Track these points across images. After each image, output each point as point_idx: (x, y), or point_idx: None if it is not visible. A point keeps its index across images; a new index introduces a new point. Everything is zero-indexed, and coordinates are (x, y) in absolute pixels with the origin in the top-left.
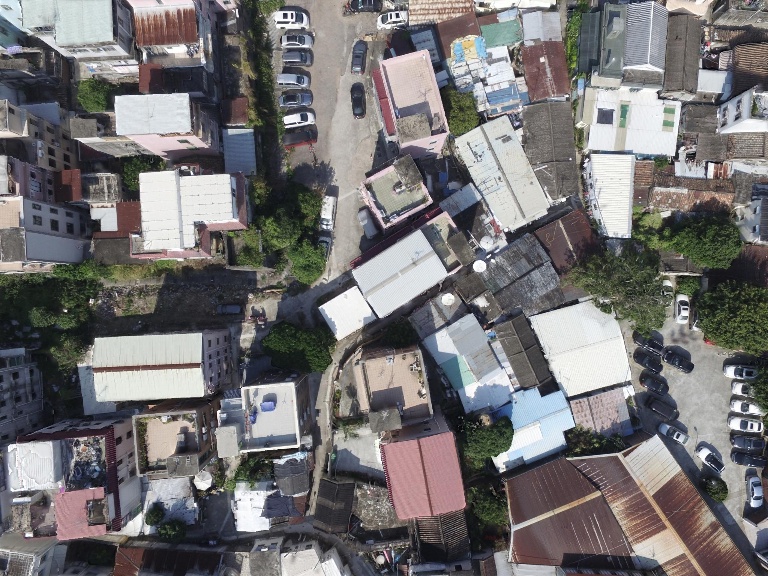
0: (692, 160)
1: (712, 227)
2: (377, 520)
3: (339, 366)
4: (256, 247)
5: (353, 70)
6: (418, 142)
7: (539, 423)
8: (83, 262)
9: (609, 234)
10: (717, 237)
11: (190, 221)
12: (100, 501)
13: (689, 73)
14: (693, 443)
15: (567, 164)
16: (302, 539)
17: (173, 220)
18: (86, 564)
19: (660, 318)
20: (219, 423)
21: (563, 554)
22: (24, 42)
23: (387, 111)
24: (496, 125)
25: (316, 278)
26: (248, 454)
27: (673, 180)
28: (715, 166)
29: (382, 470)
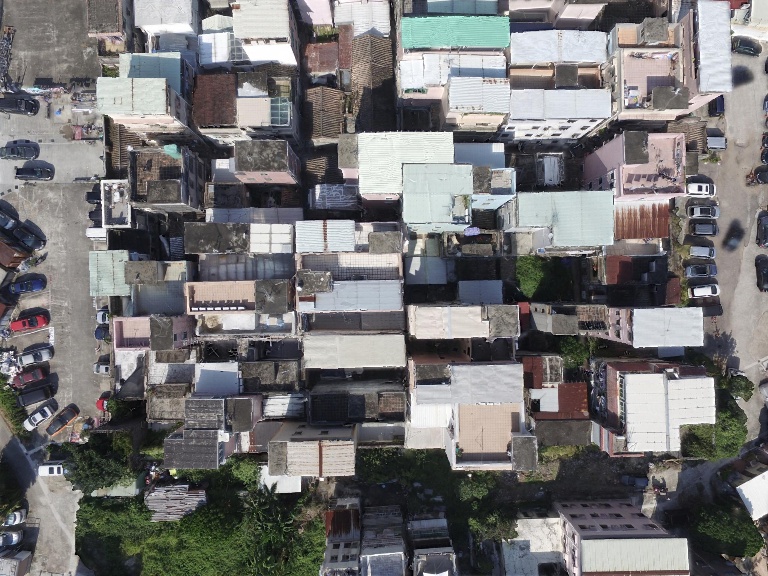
0: None
1: None
2: None
3: None
4: (708, 439)
5: (765, 245)
6: None
7: None
8: None
9: None
10: None
11: (676, 425)
12: None
13: None
14: None
15: None
16: None
17: (660, 423)
18: None
19: None
20: None
21: None
22: None
23: None
24: None
25: None
26: None
27: None
28: None
29: None
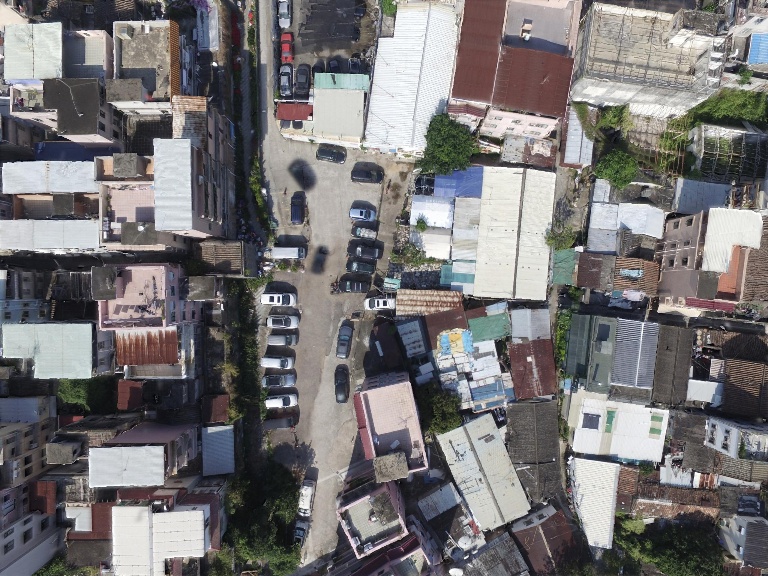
0: (678, 465)
1: (694, 558)
2: None
3: None
4: (229, 564)
5: (338, 356)
6: None
7: None
8: (56, 559)
9: (589, 543)
10: (698, 571)
11: (161, 558)
12: None
13: (678, 386)
14: None
15: (550, 465)
16: None
17: (144, 557)
18: None
19: None
20: None
21: None
22: None
23: (366, 438)
24: (479, 424)
25: None
26: None
27: (657, 489)
28: (701, 476)
29: None
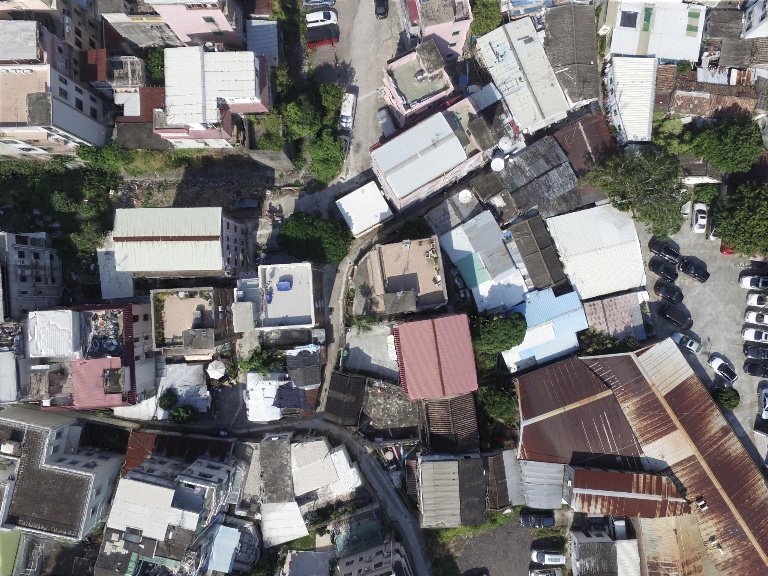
0: (715, 67)
1: (734, 127)
2: (387, 419)
3: (354, 265)
4: (276, 132)
5: None
6: (441, 29)
7: (552, 322)
8: (105, 146)
9: (629, 137)
10: (738, 136)
11: (213, 97)
12: (117, 371)
13: None
14: (706, 354)
15: (588, 67)
16: (312, 433)
17: (196, 95)
18: (99, 449)
19: (677, 221)
20: (235, 300)
21: (572, 452)
22: None
23: None
24: (518, 26)
25: (334, 177)
26: (261, 348)
27: (695, 85)
28: (738, 73)
29: (393, 369)
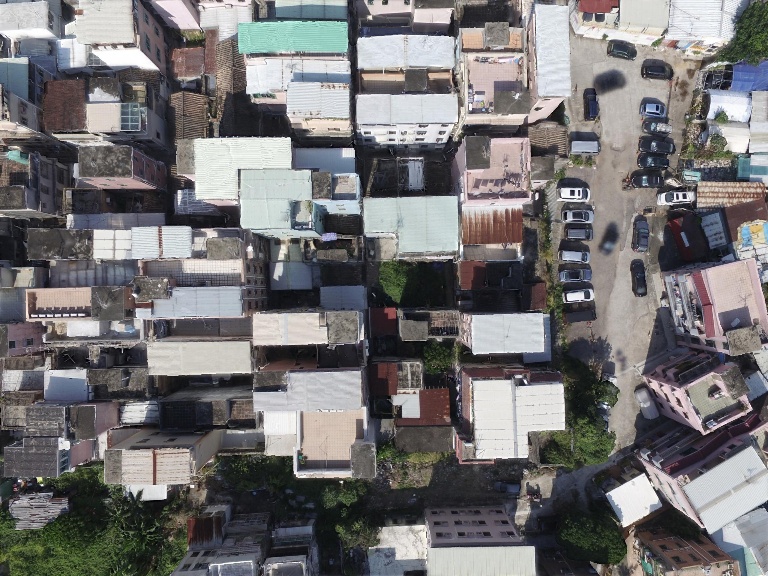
0: None
1: None
2: None
3: None
4: (567, 445)
5: (638, 249)
6: None
7: None
8: (382, 447)
9: None
10: None
11: (524, 431)
12: None
13: None
14: None
15: None
16: None
17: (507, 430)
18: None
19: None
20: None
21: None
22: (323, 219)
23: (708, 316)
24: None
25: None
26: None
27: None
28: None
29: None
